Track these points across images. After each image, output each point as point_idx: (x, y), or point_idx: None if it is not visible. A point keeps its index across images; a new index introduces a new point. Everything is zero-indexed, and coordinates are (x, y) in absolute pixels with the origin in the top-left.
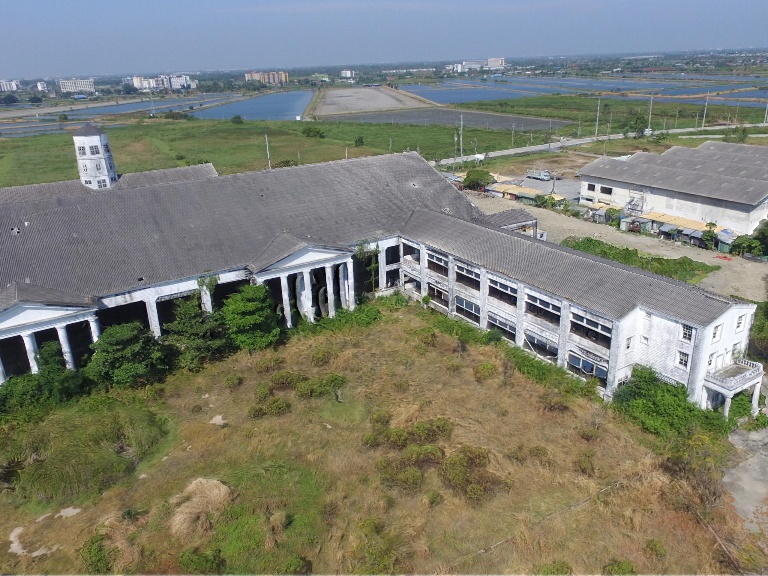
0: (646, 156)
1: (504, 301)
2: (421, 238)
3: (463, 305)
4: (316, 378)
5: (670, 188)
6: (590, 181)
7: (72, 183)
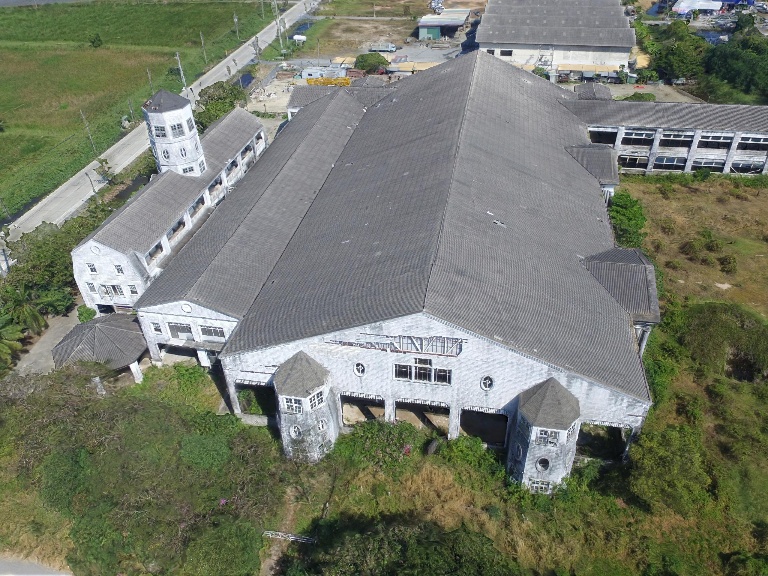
0: (494, 18)
1: (711, 148)
2: (613, 123)
3: (664, 162)
4: (702, 238)
5: (569, 43)
6: (490, 47)
7: (171, 178)
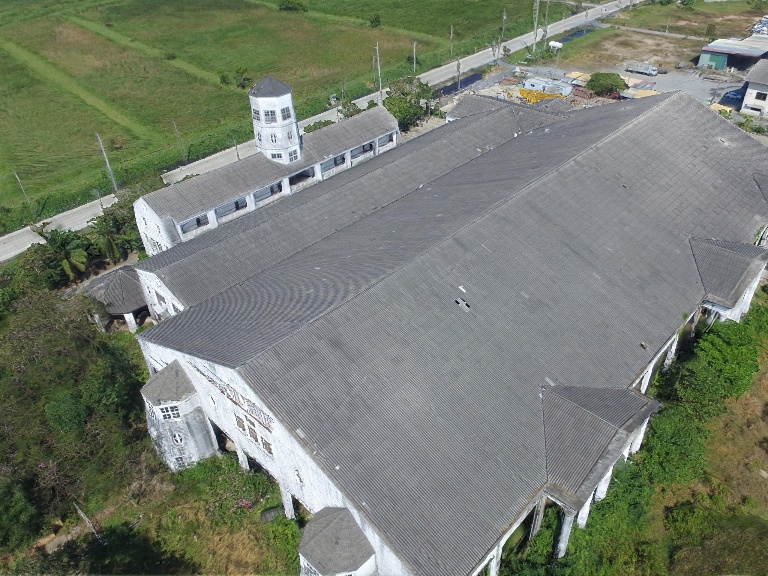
0: None
1: None
2: None
3: None
4: None
5: None
6: (761, 90)
7: (256, 160)
